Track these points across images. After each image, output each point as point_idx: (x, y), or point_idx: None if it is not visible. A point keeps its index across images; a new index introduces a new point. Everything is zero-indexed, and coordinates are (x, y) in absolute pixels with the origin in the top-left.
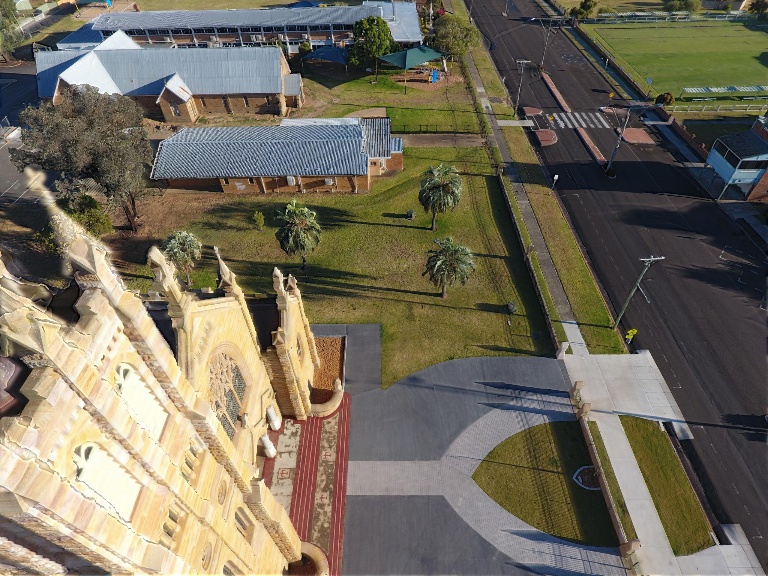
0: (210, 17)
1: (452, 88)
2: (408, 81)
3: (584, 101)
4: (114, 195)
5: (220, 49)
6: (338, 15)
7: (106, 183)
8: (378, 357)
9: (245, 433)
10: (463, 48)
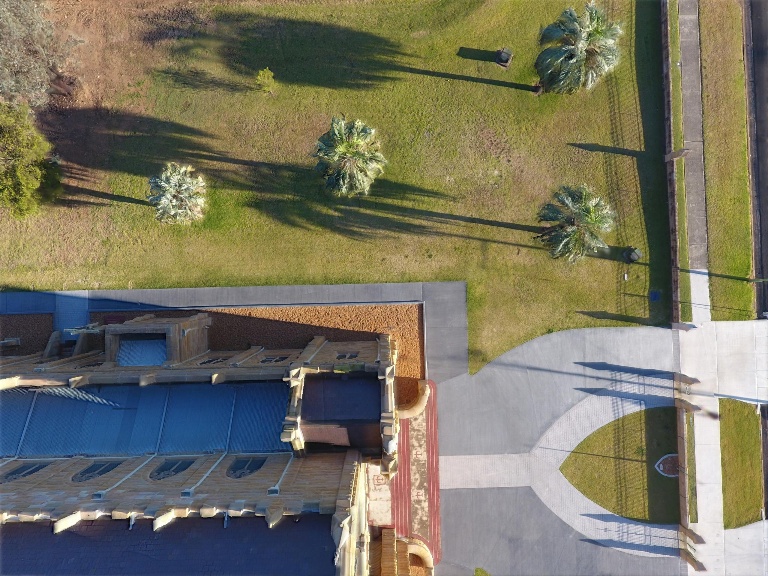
0: None
1: None
2: None
3: None
4: None
5: None
6: None
7: None
8: (464, 332)
9: None
10: None
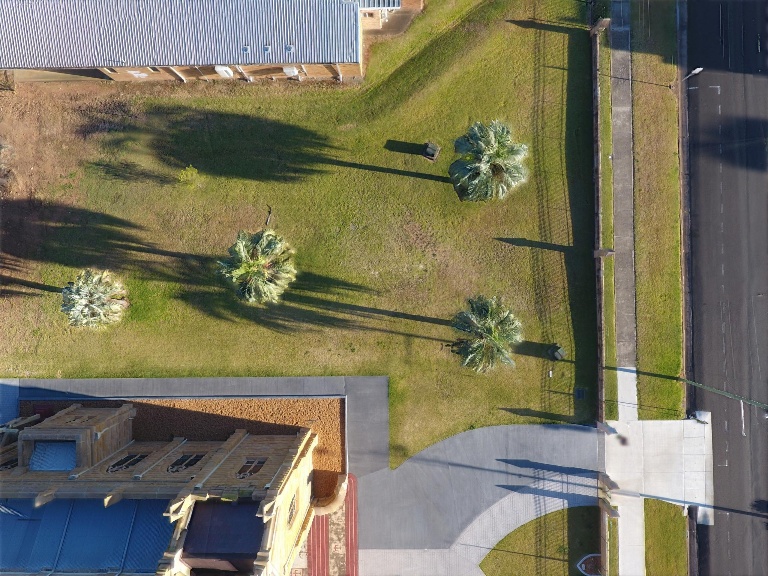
0: None
1: None
2: None
3: None
4: None
5: None
6: None
7: None
8: (385, 427)
9: None
10: None
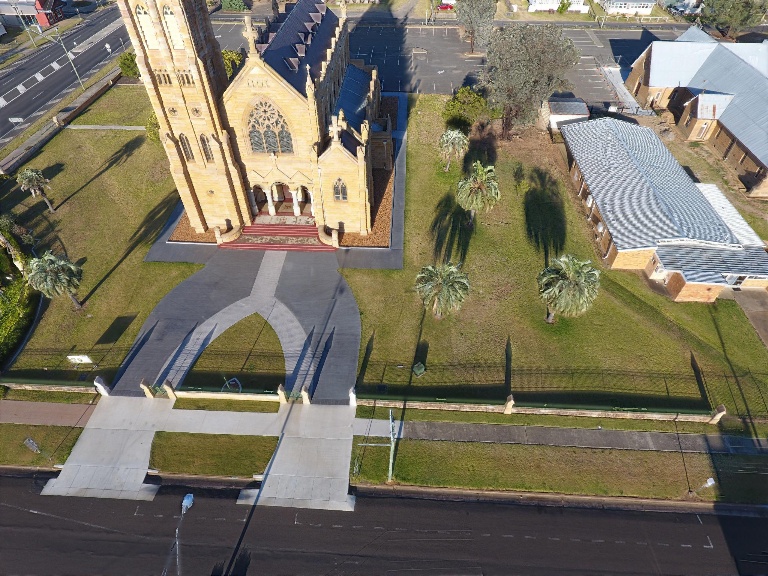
0: None
1: None
2: None
3: None
4: None
5: None
6: None
7: None
8: (368, 267)
9: (269, 160)
10: None
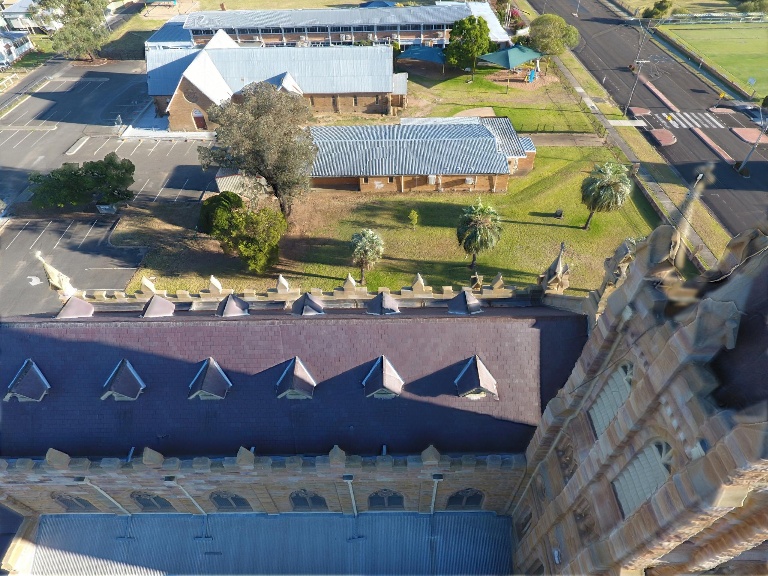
0: (300, 16)
1: (551, 88)
2: (504, 81)
3: (688, 101)
4: (277, 193)
5: (332, 48)
6: (429, 15)
7: (283, 181)
8: None
9: None
10: (562, 48)
